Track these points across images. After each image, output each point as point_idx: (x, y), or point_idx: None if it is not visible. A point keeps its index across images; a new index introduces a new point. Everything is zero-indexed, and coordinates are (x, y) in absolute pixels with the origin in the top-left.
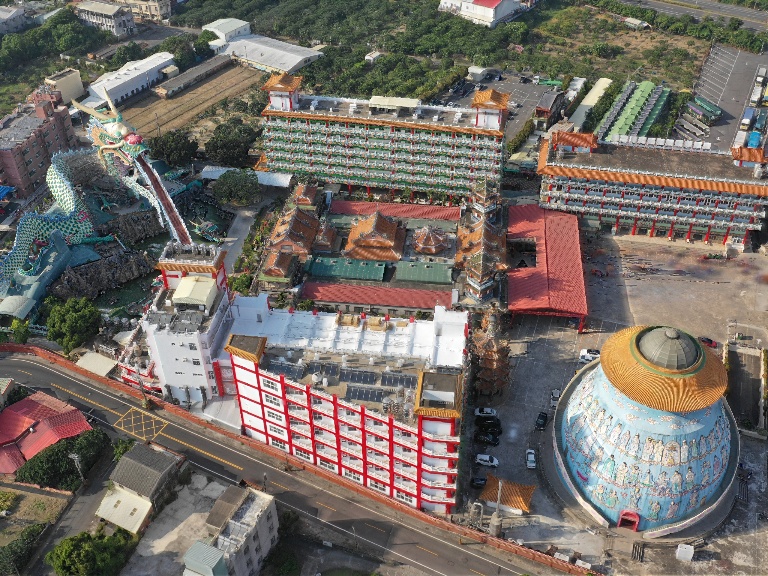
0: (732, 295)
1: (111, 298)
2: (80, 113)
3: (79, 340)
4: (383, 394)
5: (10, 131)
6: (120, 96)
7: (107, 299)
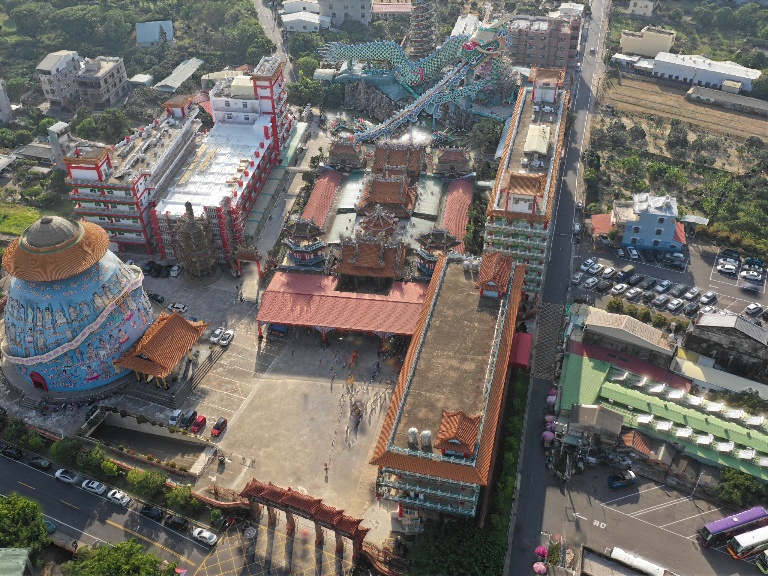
0: (300, 476)
1: (355, 114)
2: (629, 63)
3: (287, 97)
4: (122, 155)
5: (525, 22)
6: (670, 73)
7: (357, 114)
